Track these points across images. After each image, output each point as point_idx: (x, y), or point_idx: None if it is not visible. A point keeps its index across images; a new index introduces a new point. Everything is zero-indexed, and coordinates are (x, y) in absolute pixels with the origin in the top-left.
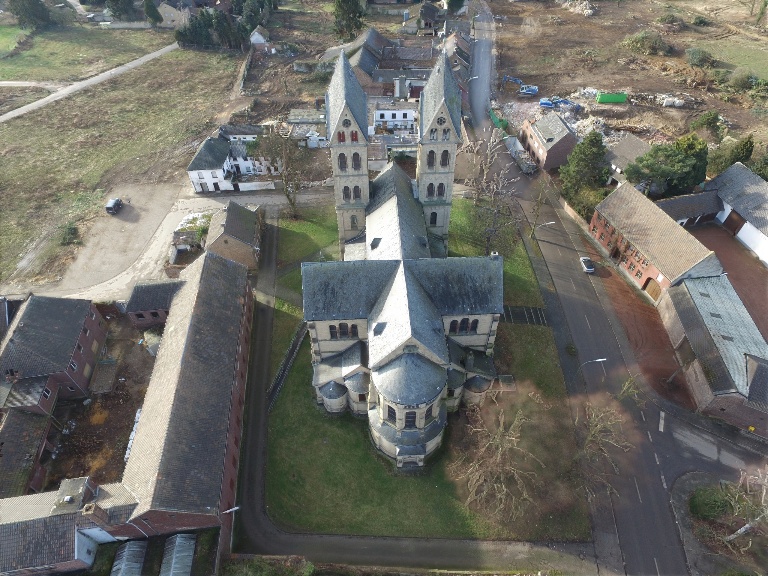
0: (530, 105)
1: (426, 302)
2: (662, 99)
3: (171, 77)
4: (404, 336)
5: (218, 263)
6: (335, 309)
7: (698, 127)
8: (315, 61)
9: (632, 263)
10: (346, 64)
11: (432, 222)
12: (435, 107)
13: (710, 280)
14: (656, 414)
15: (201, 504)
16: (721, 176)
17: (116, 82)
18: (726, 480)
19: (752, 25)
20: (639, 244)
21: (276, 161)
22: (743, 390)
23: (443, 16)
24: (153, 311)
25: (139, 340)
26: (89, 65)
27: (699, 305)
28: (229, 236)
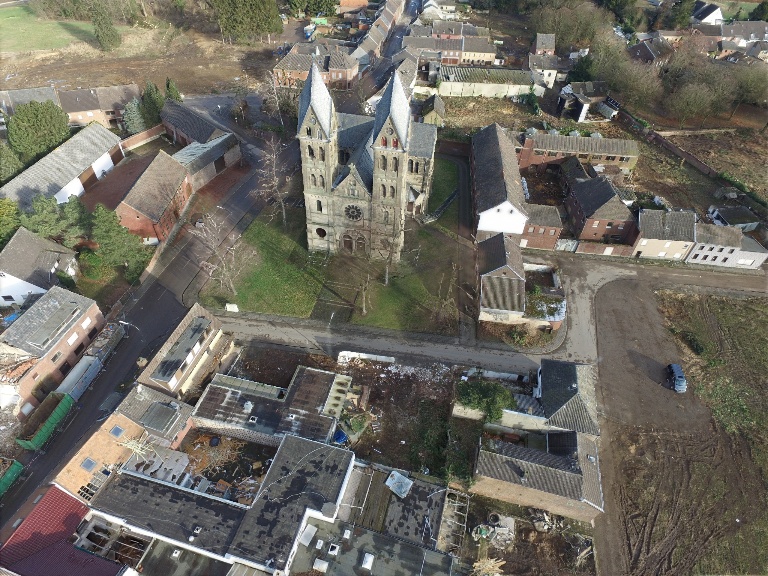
0: None
1: None
2: None
3: None
4: None
5: None
6: None
7: None
8: None
9: None
10: None
11: None
12: None
13: None
14: (262, 161)
15: None
16: None
17: None
18: (269, 132)
19: None
20: (174, 188)
21: None
22: (231, 133)
23: None
24: None
25: None
26: None
27: None
28: None
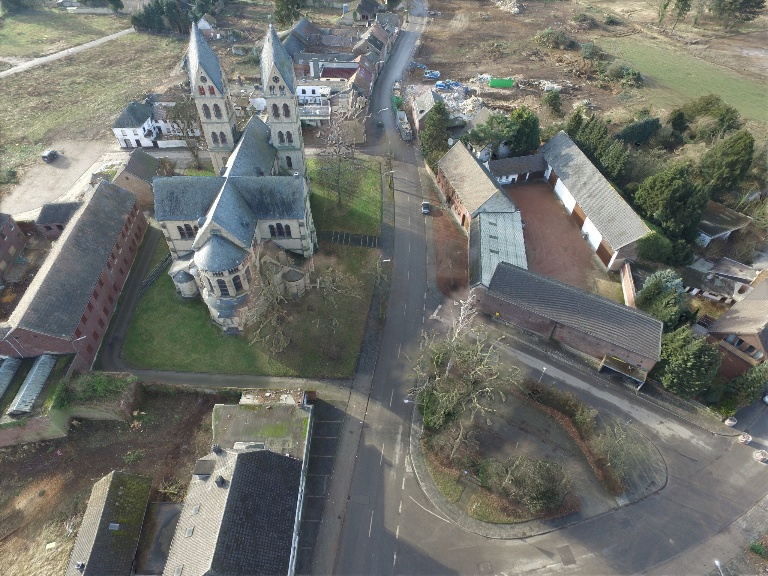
0: (429, 87)
1: (243, 207)
2: (544, 85)
3: (122, 56)
4: (208, 221)
5: (111, 189)
6: (178, 212)
7: (544, 104)
8: (251, 45)
9: (456, 205)
10: (197, 33)
11: (289, 165)
12: (269, 68)
13: (504, 215)
14: (435, 306)
15: (59, 332)
16: (549, 142)
17: (72, 59)
18: None
19: (656, 25)
20: (458, 188)
21: (191, 124)
22: (486, 283)
23: (383, 10)
24: (58, 224)
25: (50, 250)
26: (51, 44)
27: (483, 230)
28: (129, 173)
